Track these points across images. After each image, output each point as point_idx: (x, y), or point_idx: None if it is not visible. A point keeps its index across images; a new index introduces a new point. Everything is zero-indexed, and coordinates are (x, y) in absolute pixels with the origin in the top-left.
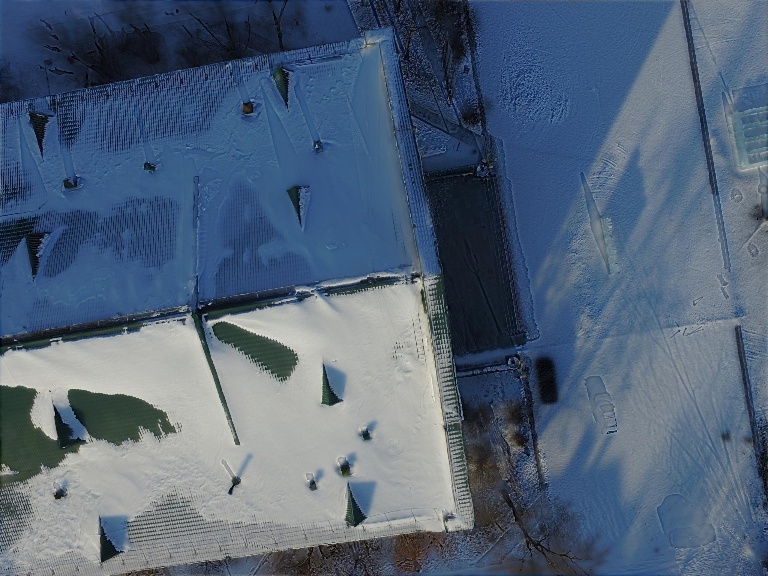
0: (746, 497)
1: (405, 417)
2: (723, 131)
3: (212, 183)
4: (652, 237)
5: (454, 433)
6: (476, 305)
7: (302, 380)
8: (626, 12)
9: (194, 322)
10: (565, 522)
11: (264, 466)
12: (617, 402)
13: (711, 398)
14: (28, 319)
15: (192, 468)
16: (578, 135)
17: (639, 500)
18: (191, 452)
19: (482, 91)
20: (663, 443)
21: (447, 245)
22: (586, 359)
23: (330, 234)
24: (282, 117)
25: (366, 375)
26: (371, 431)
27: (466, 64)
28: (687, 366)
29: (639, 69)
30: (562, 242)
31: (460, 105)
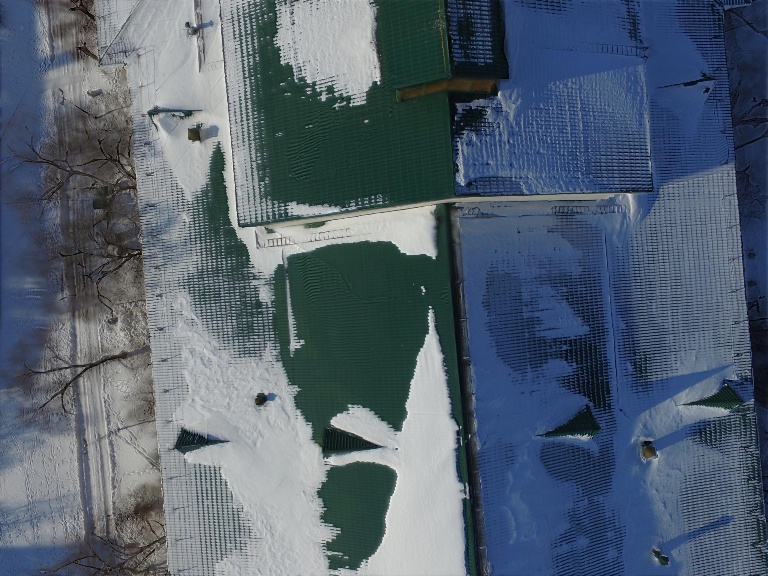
0: None
1: None
2: None
3: None
4: None
5: None
6: None
7: None
8: None
9: None
10: None
11: None
12: None
13: None
14: (494, 443)
15: (282, 568)
16: None
17: None
18: (303, 575)
19: None
20: None
21: None
22: None
23: None
24: None
25: None
26: None
27: None
28: None
29: None
30: None
31: None
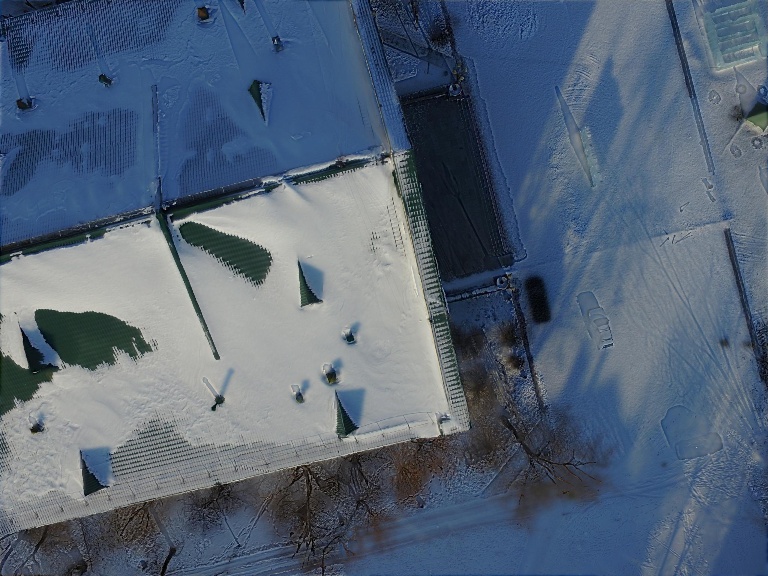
0: (750, 402)
1: (389, 315)
2: (695, 33)
3: (171, 90)
4: (633, 146)
5: (440, 325)
6: (460, 228)
7: (278, 282)
8: None
9: (159, 223)
10: (568, 444)
11: (247, 381)
12: (611, 316)
13: (706, 304)
14: None
15: (172, 389)
16: (549, 48)
17: (642, 415)
18: (170, 372)
19: (449, 12)
20: (661, 354)
21: (425, 169)
22: (576, 275)
23: (295, 125)
24: (239, 20)
25: (344, 271)
26: (355, 334)
27: None
28: (679, 274)
29: None
30: (542, 158)
31: (427, 27)
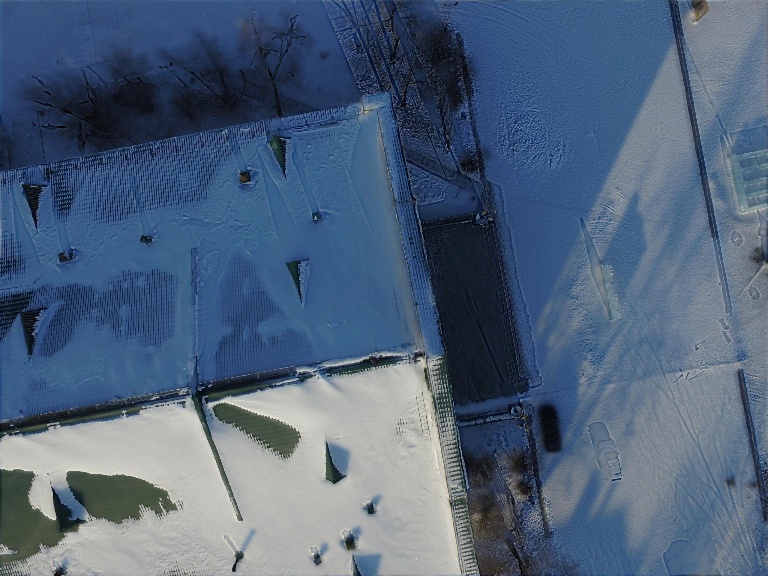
0: (752, 541)
1: (410, 490)
2: (722, 174)
3: (210, 256)
4: (653, 282)
5: (460, 507)
6: (478, 353)
7: (305, 457)
8: (623, 56)
9: (194, 404)
10: (571, 570)
11: (267, 540)
12: (621, 448)
13: (715, 443)
14: (24, 402)
15: (194, 544)
16: (577, 180)
17: (645, 546)
18: (193, 528)
19: (480, 137)
20: (668, 489)
21: (447, 293)
22: (589, 405)
23: (331, 310)
24: (280, 186)
25: (370, 451)
26: (376, 504)
27: (463, 111)
28: (690, 411)
29: (637, 113)
30: (563, 288)
31: (458, 152)
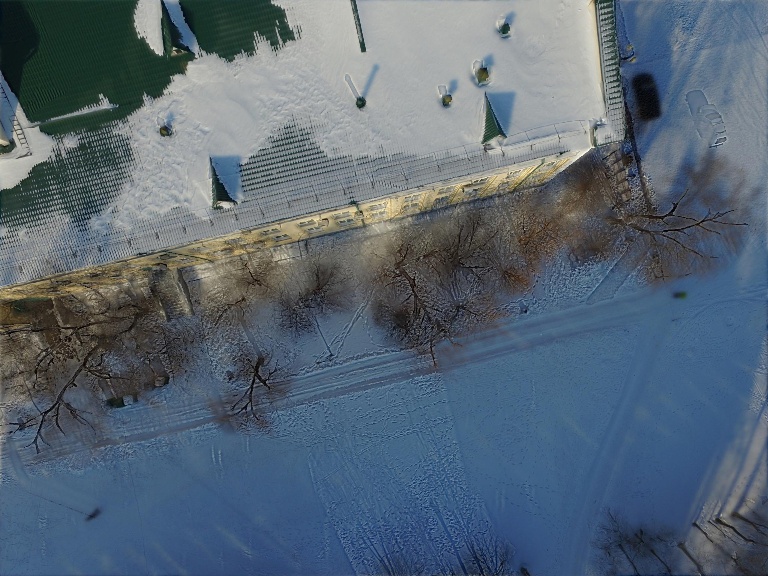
0: None
1: (546, 5)
2: None
3: None
4: None
5: (605, 6)
6: None
7: None
8: None
9: None
10: (678, 247)
11: (392, 80)
12: None
13: None
14: None
15: (312, 89)
16: None
17: (754, 217)
18: (311, 67)
19: None
20: None
21: None
22: (685, 73)
23: None
24: None
25: None
26: None
27: None
28: None
29: None
30: None
31: None
